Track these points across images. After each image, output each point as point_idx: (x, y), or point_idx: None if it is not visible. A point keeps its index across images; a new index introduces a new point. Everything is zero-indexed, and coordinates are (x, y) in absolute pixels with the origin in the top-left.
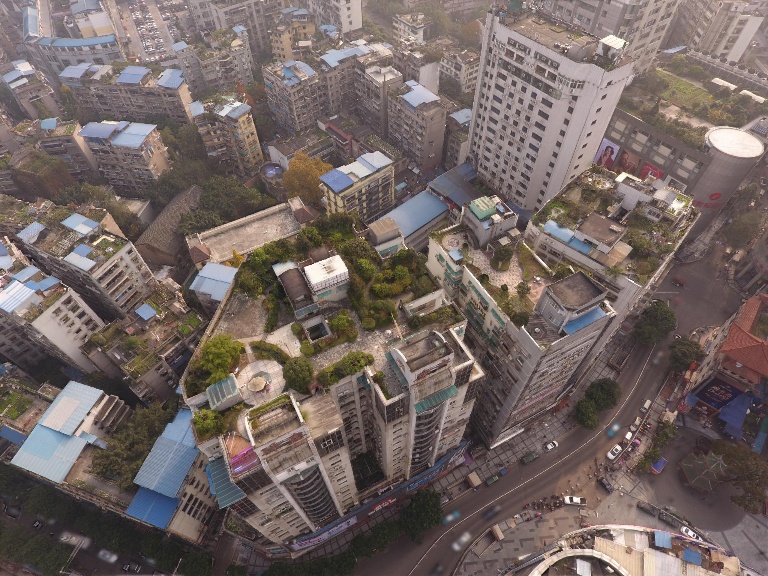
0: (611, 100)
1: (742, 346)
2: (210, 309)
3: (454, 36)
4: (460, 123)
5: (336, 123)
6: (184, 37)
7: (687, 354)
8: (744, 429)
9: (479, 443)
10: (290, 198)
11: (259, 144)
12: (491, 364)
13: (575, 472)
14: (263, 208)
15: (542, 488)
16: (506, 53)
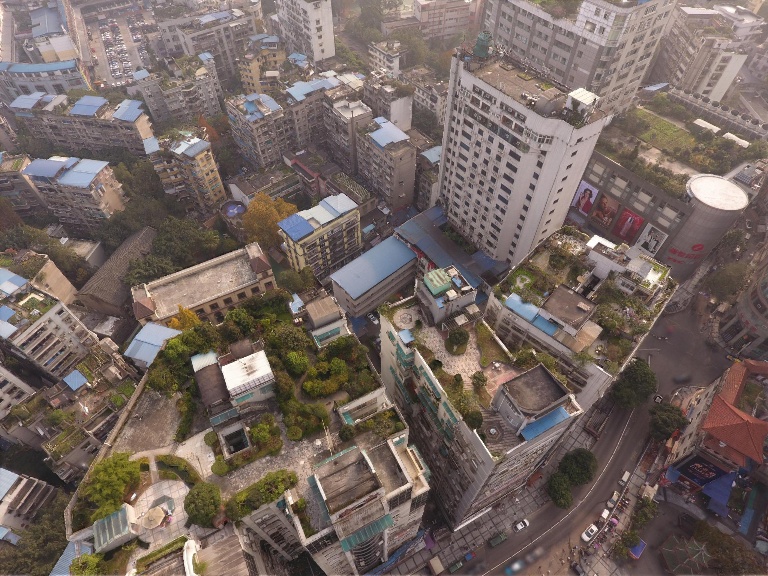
0: (583, 156)
1: (726, 424)
2: None
3: (431, 65)
4: (432, 162)
5: (303, 159)
6: (153, 61)
7: (668, 422)
8: (729, 505)
9: (443, 523)
10: (249, 242)
11: (221, 181)
12: (448, 454)
13: (547, 556)
14: (222, 250)
15: (510, 575)
16: (472, 100)
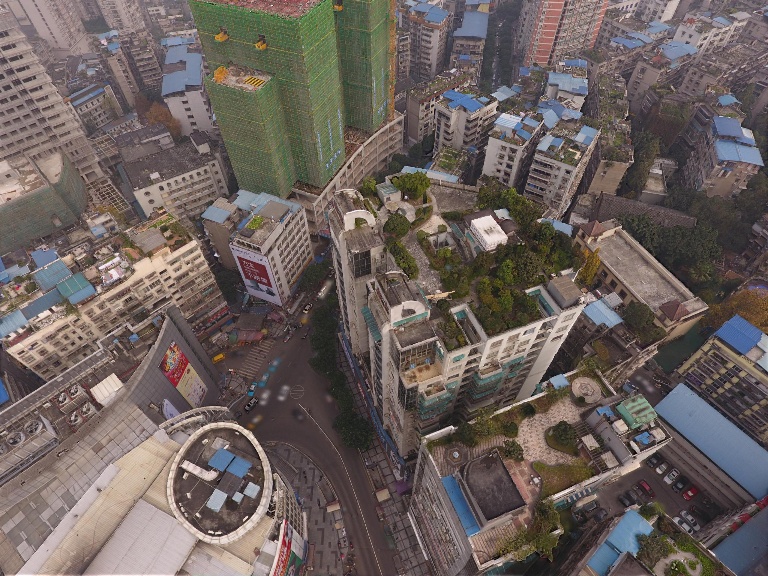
0: None
1: None
2: None
3: None
4: None
5: None
6: None
7: None
8: None
9: None
10: None
11: None
12: None
13: None
14: (697, 291)
15: (367, 572)
16: None
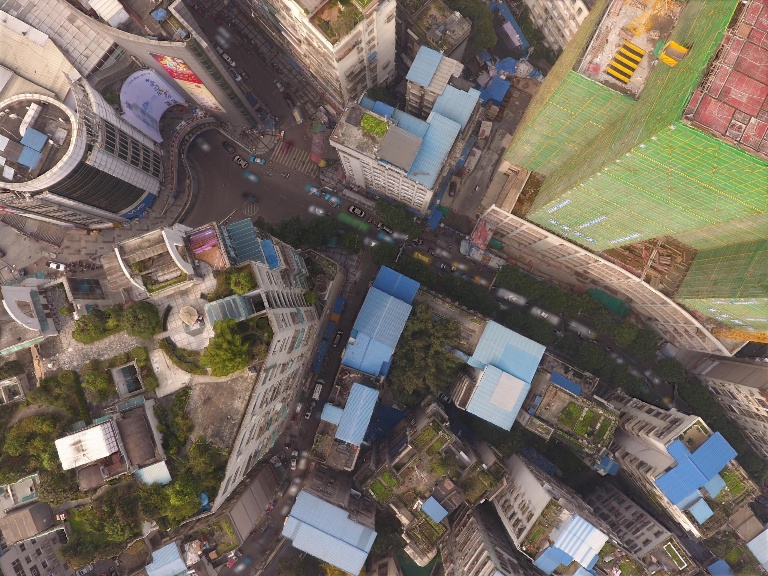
0: None
1: None
2: (366, 508)
3: None
4: None
5: None
6: None
7: None
8: None
9: None
10: None
11: None
12: None
13: None
14: None
15: None
16: None
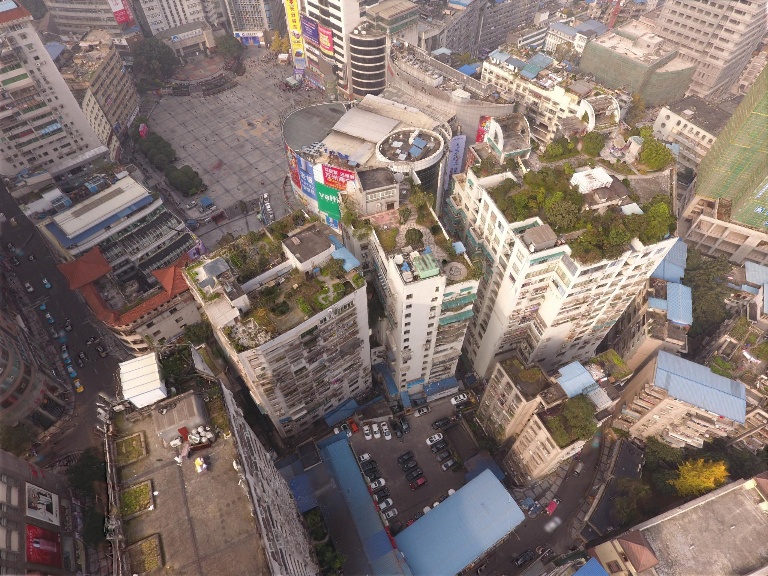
0: None
1: None
2: None
3: None
4: None
5: None
6: None
7: (205, 325)
8: None
9: None
10: None
11: None
12: None
13: None
14: None
15: None
16: None
